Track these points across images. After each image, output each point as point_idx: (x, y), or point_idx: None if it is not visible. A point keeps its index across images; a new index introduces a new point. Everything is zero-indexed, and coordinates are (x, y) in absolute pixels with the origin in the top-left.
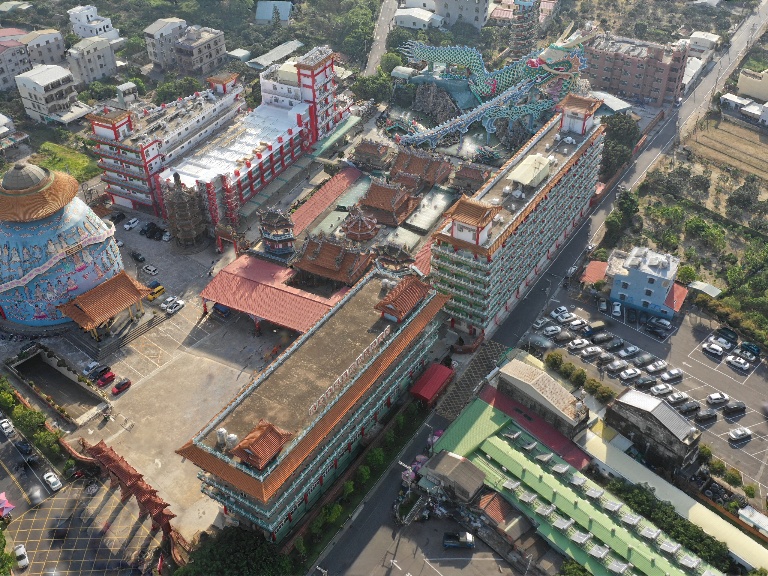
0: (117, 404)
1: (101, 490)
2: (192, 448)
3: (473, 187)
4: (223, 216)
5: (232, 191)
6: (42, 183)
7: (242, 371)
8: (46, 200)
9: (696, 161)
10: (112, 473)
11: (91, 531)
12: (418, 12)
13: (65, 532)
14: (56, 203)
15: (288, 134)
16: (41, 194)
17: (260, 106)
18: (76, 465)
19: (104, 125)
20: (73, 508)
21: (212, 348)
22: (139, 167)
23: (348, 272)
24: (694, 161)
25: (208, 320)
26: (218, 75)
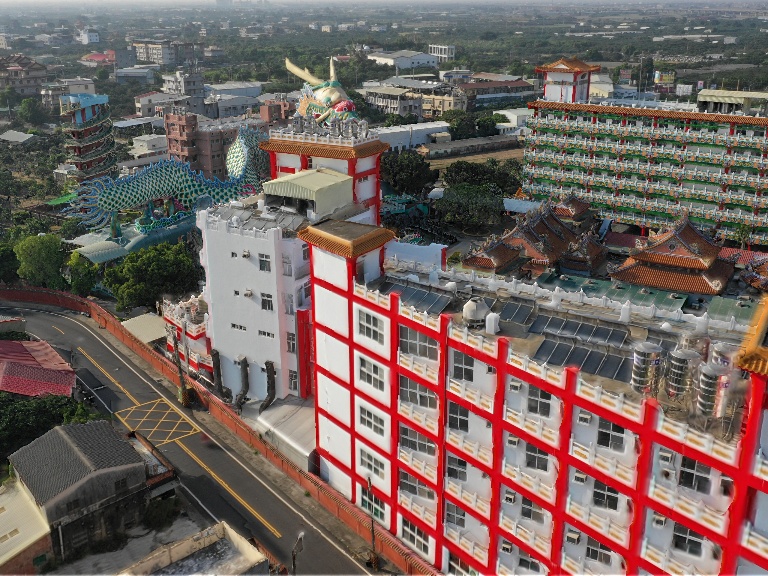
0: None
1: None
2: None
3: (585, 225)
4: None
5: None
6: None
7: None
8: None
9: (439, 179)
10: None
11: None
12: None
13: None
14: None
15: None
16: None
17: None
18: None
19: None
20: None
21: None
22: None
23: None
24: (438, 179)
25: None
26: (337, 234)
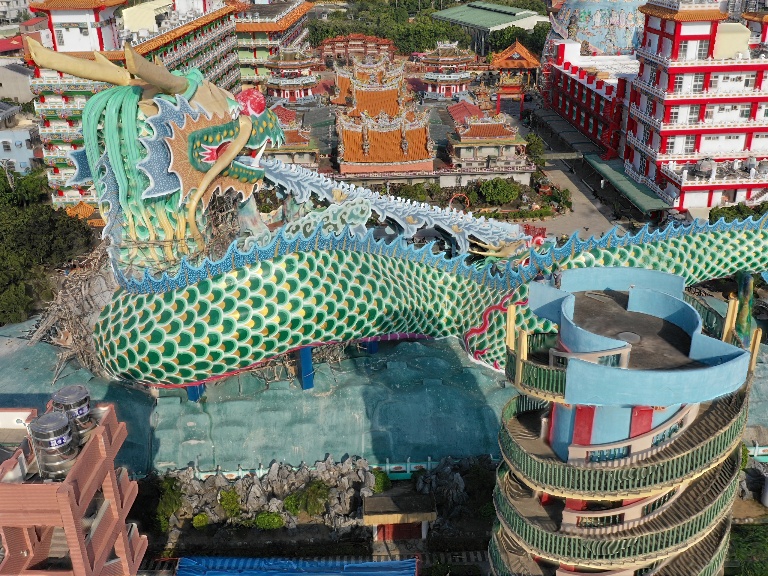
0: None
1: None
2: None
3: None
4: None
5: None
6: None
7: None
8: None
9: None
10: None
11: None
12: None
13: None
14: None
15: None
16: None
17: None
18: None
19: None
20: None
21: None
22: None
23: None
24: None
25: None
26: None
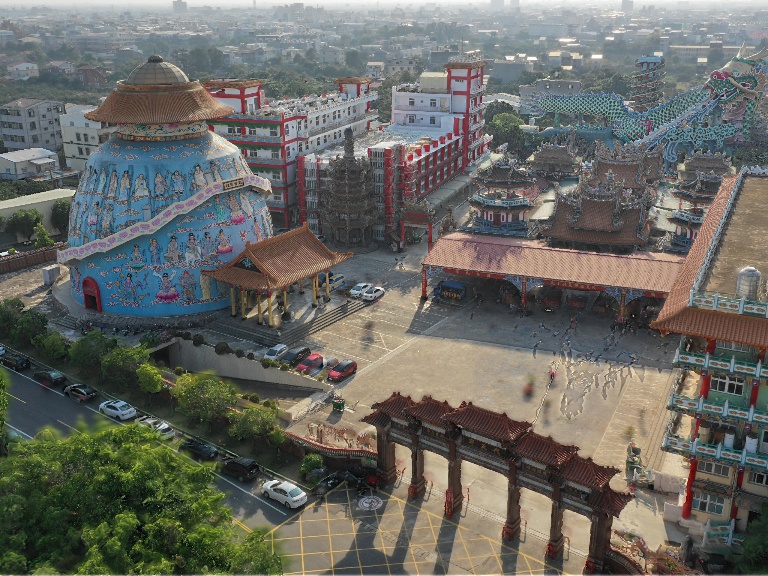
0: (346, 392)
1: (391, 503)
2: (688, 314)
3: None
4: (396, 209)
5: (412, 170)
6: (190, 83)
7: (535, 349)
8: (197, 104)
9: None
10: (430, 451)
11: (413, 568)
12: (504, 100)
13: (356, 573)
14: (211, 111)
15: (447, 139)
16: (190, 95)
17: (393, 125)
18: (324, 464)
19: (227, 94)
20: (349, 533)
21: (463, 329)
22: (272, 151)
23: (637, 229)
24: None
25: (433, 305)
26: None
